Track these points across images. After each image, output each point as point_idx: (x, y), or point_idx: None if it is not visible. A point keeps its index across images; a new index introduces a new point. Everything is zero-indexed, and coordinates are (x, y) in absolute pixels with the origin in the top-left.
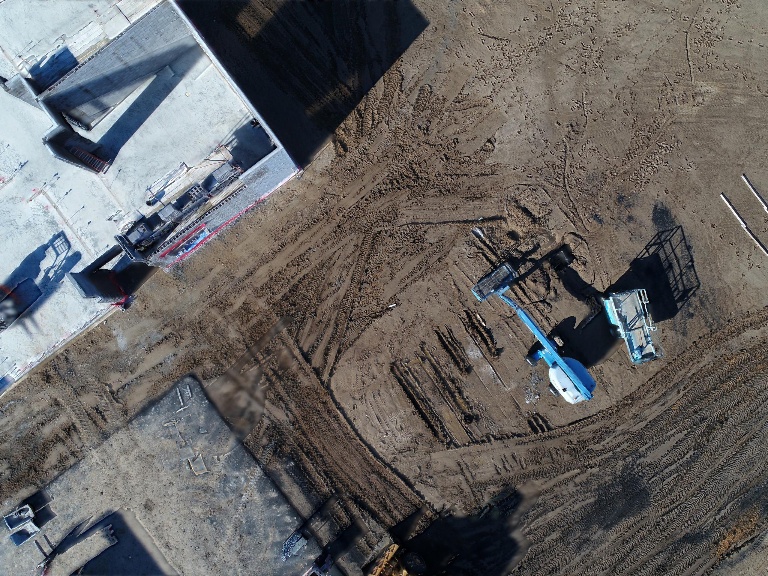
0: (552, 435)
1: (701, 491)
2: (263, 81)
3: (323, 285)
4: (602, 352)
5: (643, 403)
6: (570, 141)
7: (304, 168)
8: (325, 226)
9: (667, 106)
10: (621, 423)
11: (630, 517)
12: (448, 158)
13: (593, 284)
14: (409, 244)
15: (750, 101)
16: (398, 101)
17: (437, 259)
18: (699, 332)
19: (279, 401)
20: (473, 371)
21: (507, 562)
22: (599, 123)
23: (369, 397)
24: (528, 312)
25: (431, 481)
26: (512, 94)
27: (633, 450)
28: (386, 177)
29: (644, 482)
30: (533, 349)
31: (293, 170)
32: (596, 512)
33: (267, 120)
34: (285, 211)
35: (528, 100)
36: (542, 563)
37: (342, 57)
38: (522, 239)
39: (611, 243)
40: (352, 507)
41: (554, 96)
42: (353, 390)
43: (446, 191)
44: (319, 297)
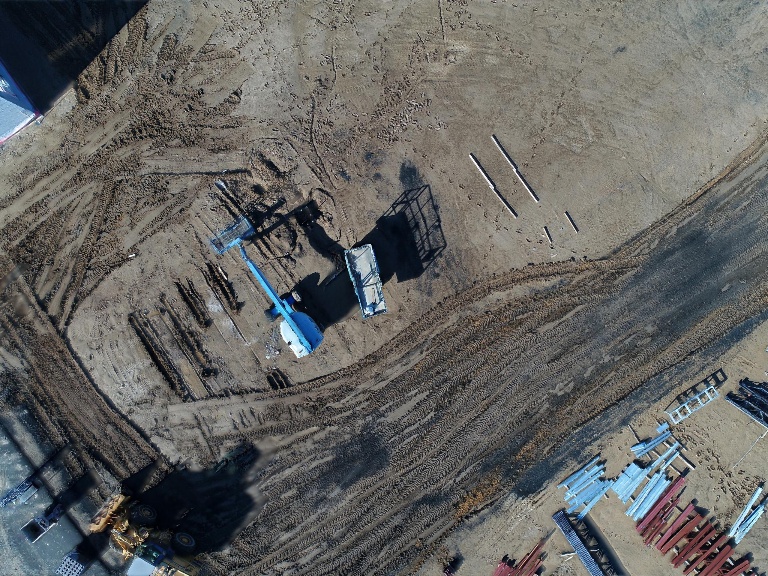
0: (292, 391)
1: (441, 452)
2: (4, 24)
3: (61, 233)
4: (345, 310)
5: (385, 362)
6: (318, 96)
7: (44, 114)
8: (65, 173)
9: (418, 64)
10: (362, 382)
11: (368, 476)
12: (192, 109)
13: (339, 241)
14: (150, 194)
15: (502, 61)
16: (142, 49)
17: (178, 210)
18: (444, 293)
19: (14, 348)
20: (213, 324)
21: (242, 517)
22: (348, 79)
23: (106, 347)
24: (271, 267)
25: (167, 434)
26: (260, 46)
27: (373, 409)
28: (128, 126)
29: (384, 442)
30: (274, 304)
31: (23, 113)
32: (334, 470)
33: (7, 64)
34: (24, 156)
35: (276, 53)
36: (278, 520)
37: (86, 3)
38: (266, 193)
39: (358, 200)
40: (86, 457)
41: (303, 50)
42: (90, 340)
43: (190, 142)
44: (57, 244)
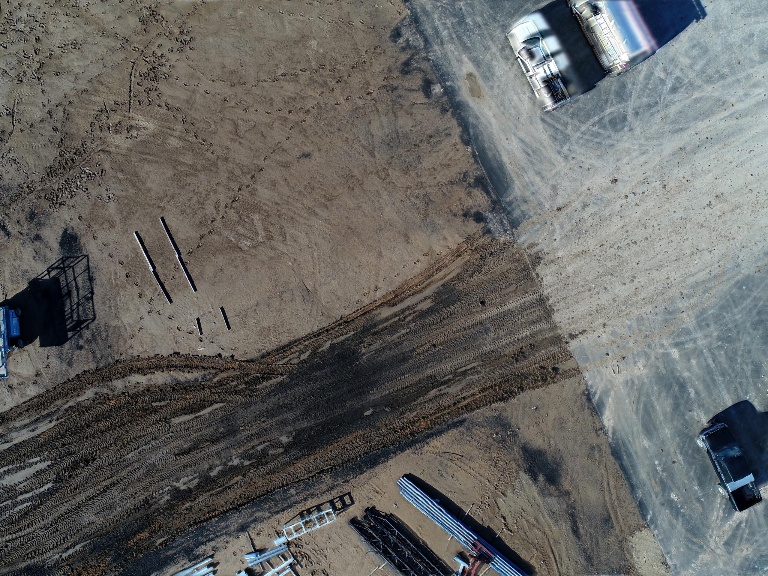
0: None
1: (52, 525)
2: None
3: None
4: None
5: (13, 424)
6: None
7: None
8: None
9: (99, 132)
10: None
11: None
12: None
13: None
14: None
15: (185, 145)
16: None
17: None
18: (85, 365)
19: None
20: None
21: None
22: (25, 134)
23: None
24: None
25: None
26: None
27: None
28: None
29: None
30: None
31: None
32: None
33: None
34: None
35: None
36: None
37: None
38: None
39: (14, 257)
40: None
41: None
42: None
43: None
44: None
